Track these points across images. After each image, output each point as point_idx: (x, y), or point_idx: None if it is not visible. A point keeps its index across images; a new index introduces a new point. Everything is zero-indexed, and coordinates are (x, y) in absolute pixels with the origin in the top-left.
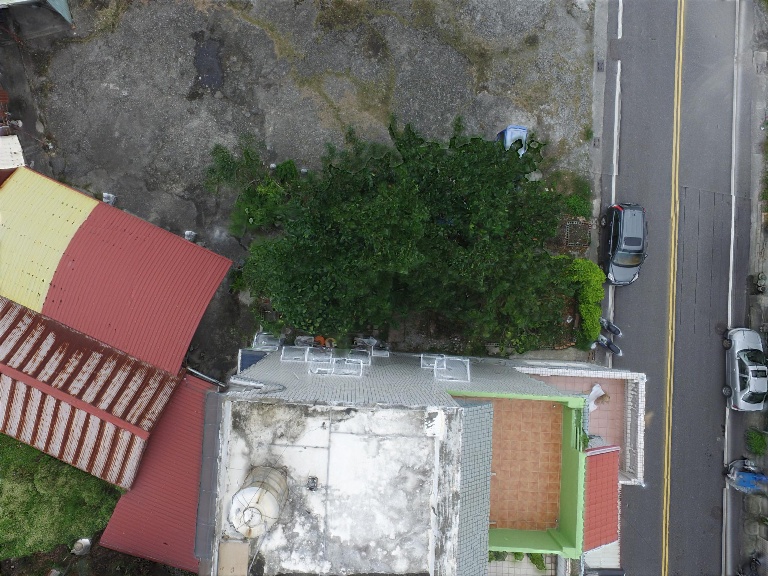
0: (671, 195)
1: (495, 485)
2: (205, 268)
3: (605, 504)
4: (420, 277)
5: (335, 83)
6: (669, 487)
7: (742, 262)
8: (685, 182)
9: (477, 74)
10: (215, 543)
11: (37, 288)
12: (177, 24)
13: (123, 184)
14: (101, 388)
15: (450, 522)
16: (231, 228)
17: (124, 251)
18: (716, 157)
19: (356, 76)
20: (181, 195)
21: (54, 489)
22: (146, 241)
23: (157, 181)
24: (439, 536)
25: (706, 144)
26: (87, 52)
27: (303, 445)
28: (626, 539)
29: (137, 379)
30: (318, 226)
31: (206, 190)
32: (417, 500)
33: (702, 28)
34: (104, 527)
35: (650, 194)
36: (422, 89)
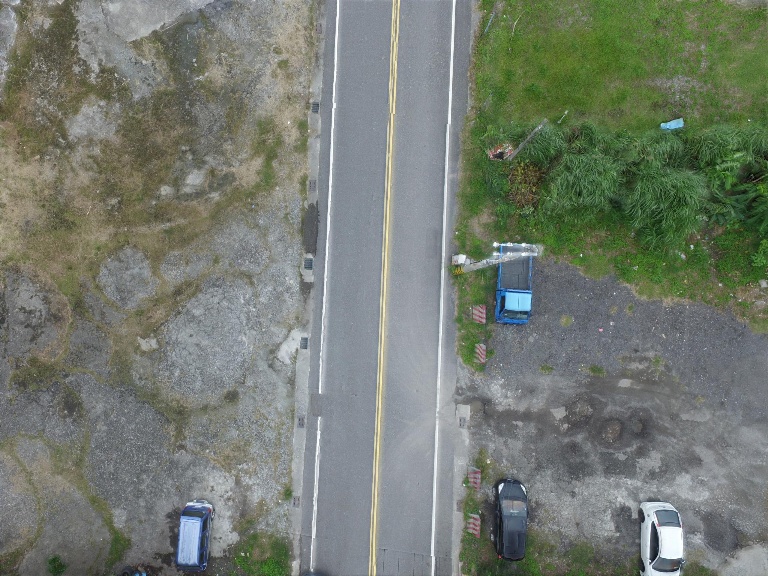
0: (369, 558)
1: None
2: None
3: None
4: None
5: (28, 446)
6: None
7: None
8: (384, 544)
9: (175, 433)
10: None
11: None
12: None
13: None
14: None
15: None
16: None
17: None
18: (416, 516)
19: (50, 438)
20: None
21: None
22: None
23: None
24: None
25: (405, 504)
26: None
27: None
28: None
29: None
30: None
31: None
32: None
33: (403, 382)
34: None
35: (348, 557)
36: (117, 451)
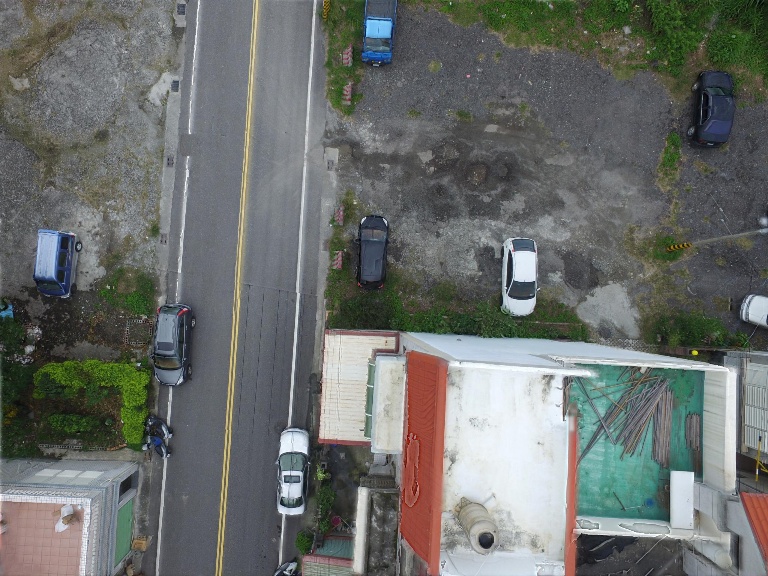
0: (234, 293)
1: None
2: None
3: None
4: None
5: None
6: None
7: (306, 360)
8: (249, 279)
9: (44, 170)
10: None
11: None
12: None
13: None
14: None
15: None
16: None
17: None
18: (282, 254)
19: None
20: None
21: None
22: None
23: None
24: None
25: (271, 241)
26: None
27: None
28: None
29: None
30: None
31: None
32: None
33: (272, 124)
34: None
35: (213, 292)
36: None
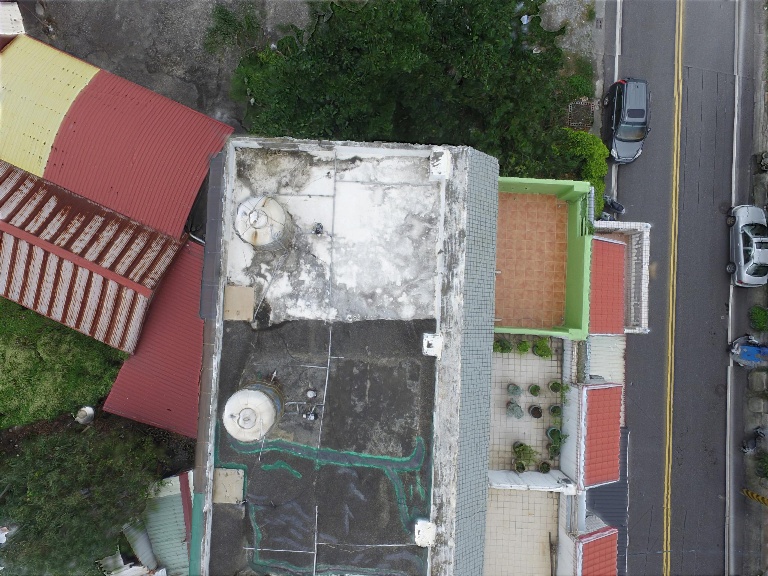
0: (674, 75)
1: (500, 284)
2: (207, 133)
3: (611, 294)
4: (424, 90)
5: None
6: (673, 365)
7: (746, 142)
8: (688, 62)
9: None
10: (220, 281)
11: (38, 151)
12: None
13: (124, 66)
14: (103, 248)
15: (456, 258)
16: (232, 110)
17: (125, 115)
18: (719, 37)
19: None
20: (182, 77)
21: (57, 356)
22: (147, 106)
23: (158, 63)
24: (446, 272)
25: (709, 24)
26: None
27: (308, 194)
28: (630, 417)
29: (139, 242)
30: (320, 55)
31: (207, 72)
32: (423, 247)
33: None
34: (108, 393)
35: (653, 74)
36: None
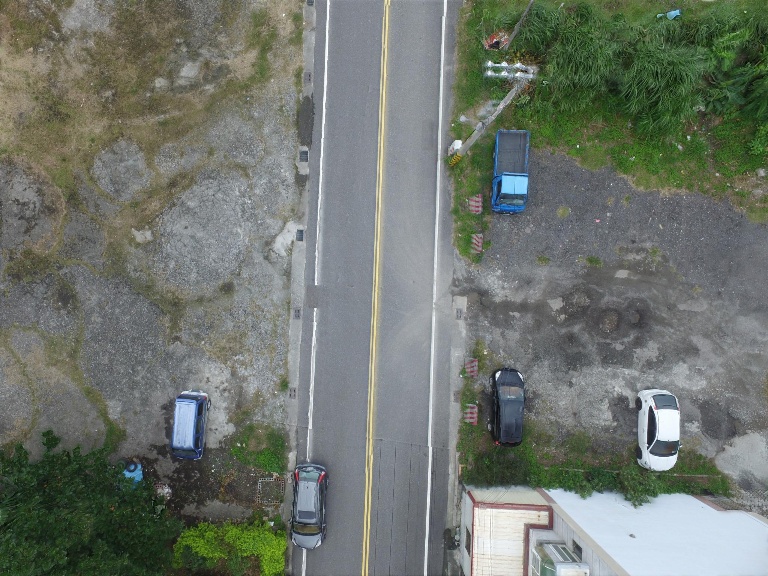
0: (366, 448)
1: None
2: None
3: None
4: None
5: (22, 337)
6: None
7: (439, 515)
8: (381, 434)
9: (170, 324)
10: None
11: None
12: None
13: None
14: None
15: None
16: None
17: None
18: (413, 407)
19: (44, 330)
20: None
21: None
22: None
23: None
24: None
25: (402, 394)
26: None
27: None
28: None
29: None
30: None
31: None
32: None
33: (400, 274)
34: None
35: (345, 447)
36: (112, 342)
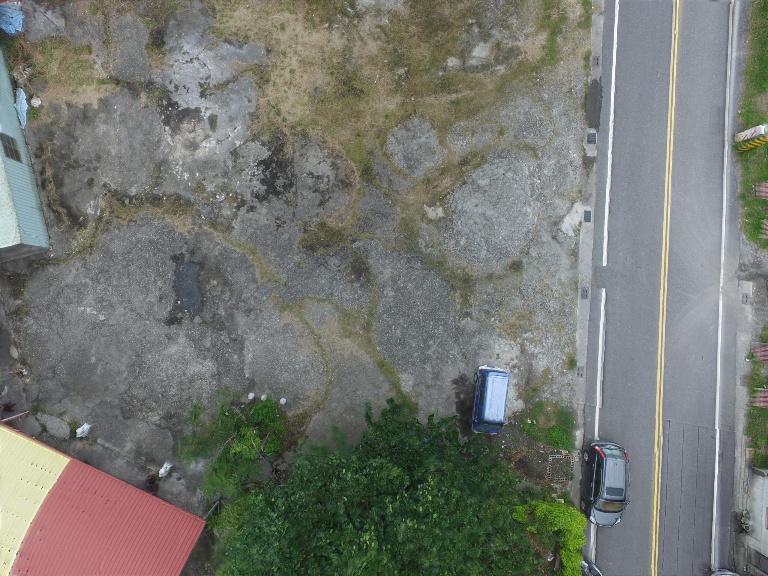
0: (655, 429)
1: None
2: (177, 533)
3: None
4: None
5: (316, 308)
6: None
7: (726, 498)
8: (669, 415)
9: (460, 300)
10: None
11: (3, 557)
12: (157, 246)
13: (98, 412)
14: None
15: None
16: (207, 458)
17: (94, 518)
18: (700, 389)
19: (338, 302)
20: (157, 423)
21: None
22: (117, 504)
23: (133, 409)
24: None
25: (690, 376)
26: (64, 275)
27: None
28: None
29: None
30: (287, 560)
31: (183, 418)
32: None
33: (687, 257)
34: None
35: (634, 427)
36: (404, 316)
